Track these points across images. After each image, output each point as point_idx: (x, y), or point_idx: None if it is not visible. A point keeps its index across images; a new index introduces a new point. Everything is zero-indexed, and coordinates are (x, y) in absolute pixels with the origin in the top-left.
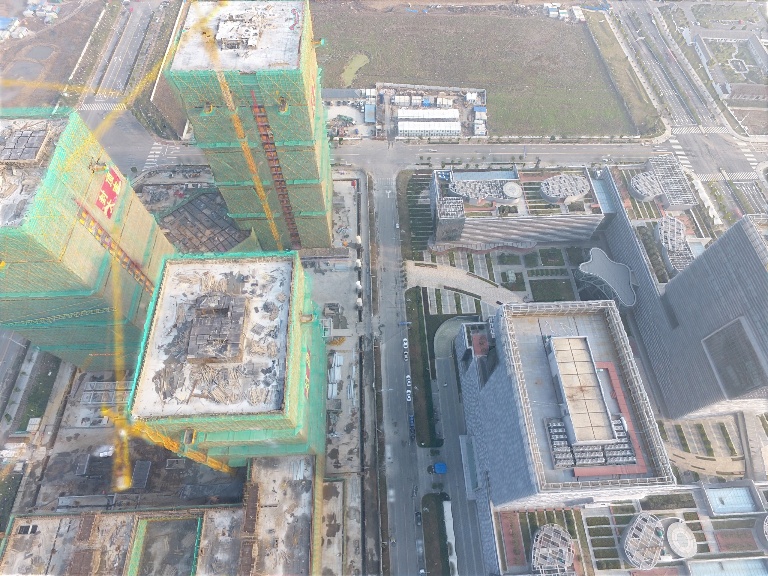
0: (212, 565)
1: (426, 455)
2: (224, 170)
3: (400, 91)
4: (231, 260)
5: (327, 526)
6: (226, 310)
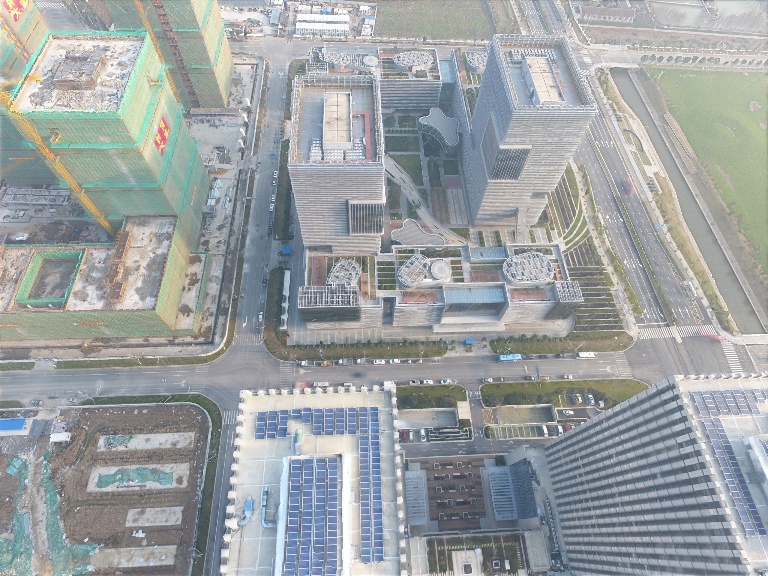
0: (88, 279)
1: (278, 245)
2: (120, 15)
3: (304, 3)
4: (98, 37)
5: (189, 280)
6: (87, 58)
